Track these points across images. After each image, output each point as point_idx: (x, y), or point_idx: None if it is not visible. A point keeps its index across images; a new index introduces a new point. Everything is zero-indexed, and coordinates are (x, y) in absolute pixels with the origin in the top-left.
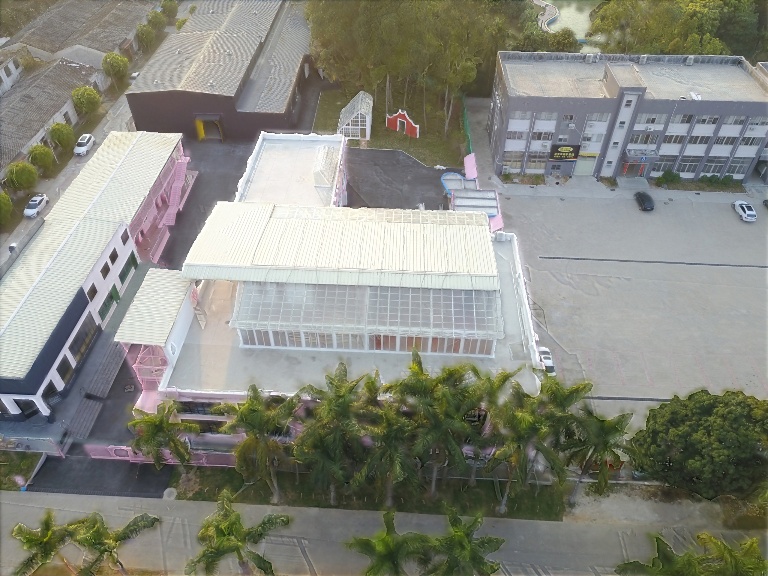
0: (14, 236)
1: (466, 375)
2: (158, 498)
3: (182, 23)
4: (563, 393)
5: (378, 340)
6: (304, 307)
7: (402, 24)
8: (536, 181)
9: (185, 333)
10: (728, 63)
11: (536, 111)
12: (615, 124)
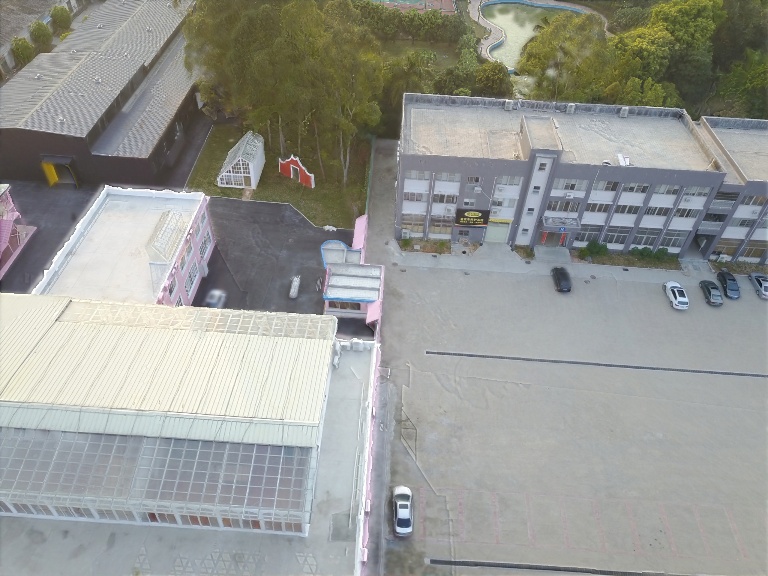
0: None
1: None
2: None
3: None
4: None
5: (150, 513)
6: (52, 467)
7: (278, 62)
8: (440, 248)
9: None
10: (668, 116)
11: (435, 171)
12: (528, 189)
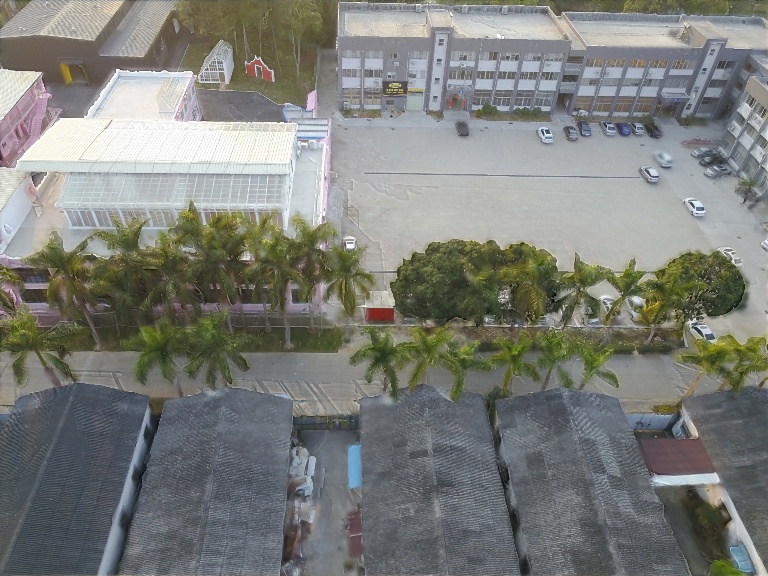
0: None
1: (234, 221)
2: None
3: None
4: (309, 231)
5: None
6: (122, 191)
7: None
8: (373, 115)
9: (21, 220)
10: (538, 12)
11: (364, 50)
12: (433, 61)
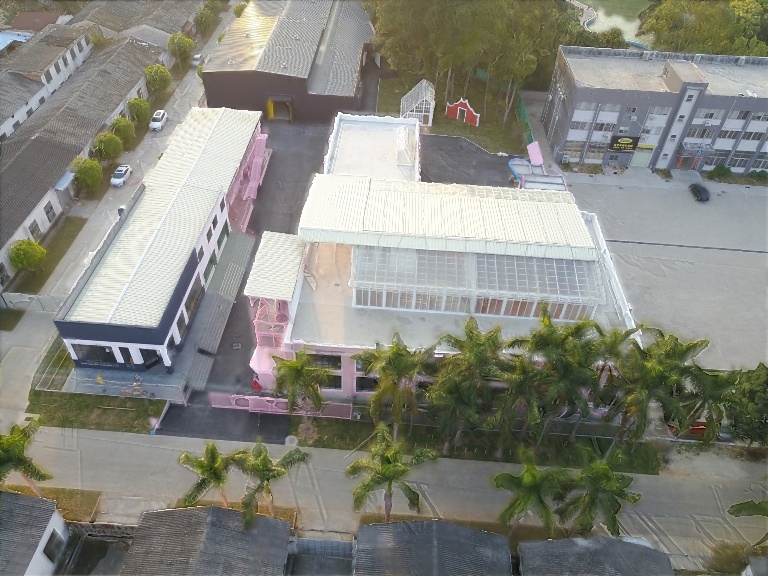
0: (104, 203)
1: (591, 330)
2: (281, 444)
3: (240, 8)
4: (681, 349)
5: (485, 303)
6: (417, 270)
7: (477, 14)
8: (595, 170)
9: (299, 293)
10: None
11: (601, 102)
12: (675, 118)
